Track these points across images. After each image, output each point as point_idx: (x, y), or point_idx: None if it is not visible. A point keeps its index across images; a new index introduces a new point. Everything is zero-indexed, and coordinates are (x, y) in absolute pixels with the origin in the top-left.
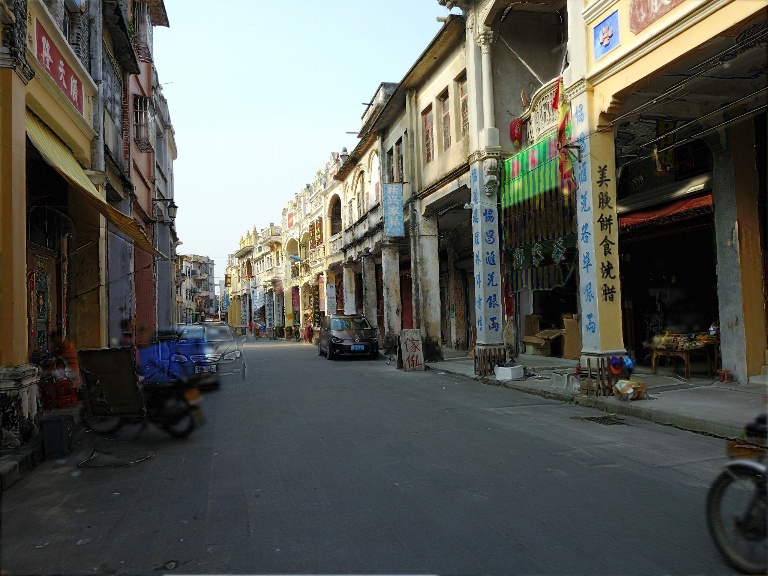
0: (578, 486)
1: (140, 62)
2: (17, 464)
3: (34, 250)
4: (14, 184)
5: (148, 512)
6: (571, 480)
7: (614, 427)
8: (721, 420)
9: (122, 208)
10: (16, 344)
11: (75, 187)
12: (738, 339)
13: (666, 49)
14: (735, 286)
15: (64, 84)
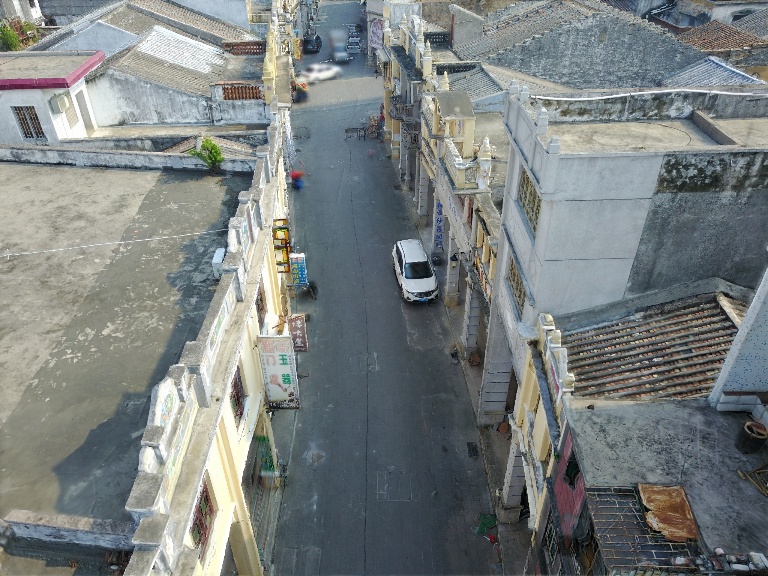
0: None
1: None
2: None
3: None
4: None
5: None
6: None
7: None
8: None
9: None
10: None
11: None
12: None
13: None
14: None
15: None
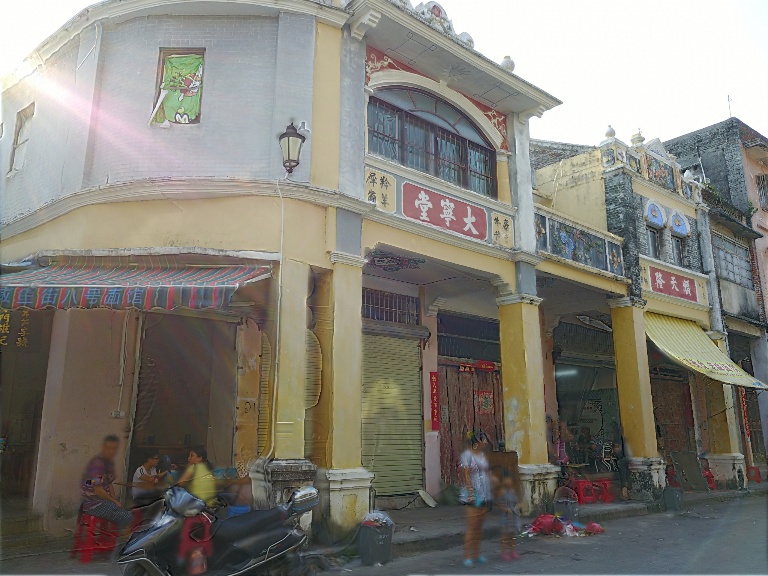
0: None
1: None
2: (646, 507)
3: None
4: (639, 363)
5: (678, 530)
6: None
7: None
8: None
9: (761, 343)
10: (647, 446)
11: (672, 359)
12: None
13: None
14: None
15: (676, 289)
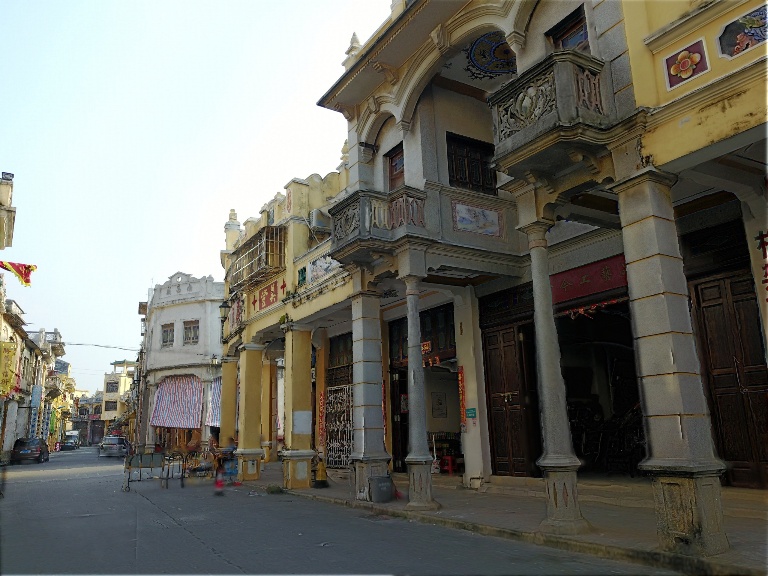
0: None
1: None
2: None
3: None
4: None
5: None
6: None
7: None
8: None
9: None
10: None
11: None
12: None
13: None
14: None
15: None
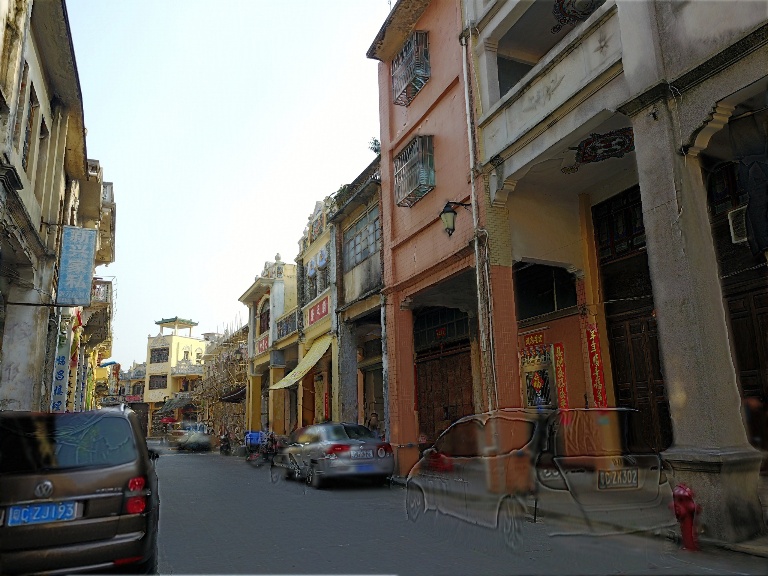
0: None
1: (428, 81)
2: None
3: (519, 329)
4: None
5: None
6: None
7: None
8: None
9: None
10: None
11: None
12: None
13: None
14: None
15: None
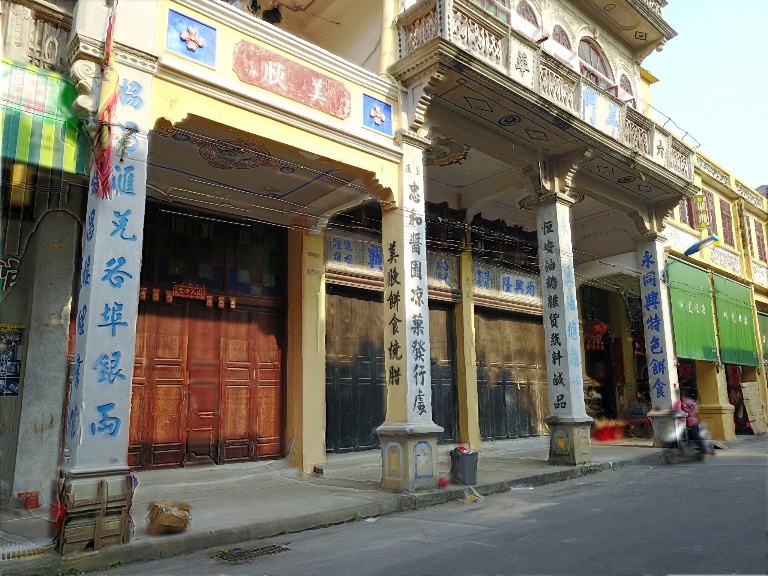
0: (605, 533)
1: None
2: None
3: None
4: None
5: None
6: (589, 536)
7: (306, 546)
8: (326, 508)
9: None
10: None
11: None
12: (51, 446)
13: (278, 127)
14: (57, 377)
15: None
